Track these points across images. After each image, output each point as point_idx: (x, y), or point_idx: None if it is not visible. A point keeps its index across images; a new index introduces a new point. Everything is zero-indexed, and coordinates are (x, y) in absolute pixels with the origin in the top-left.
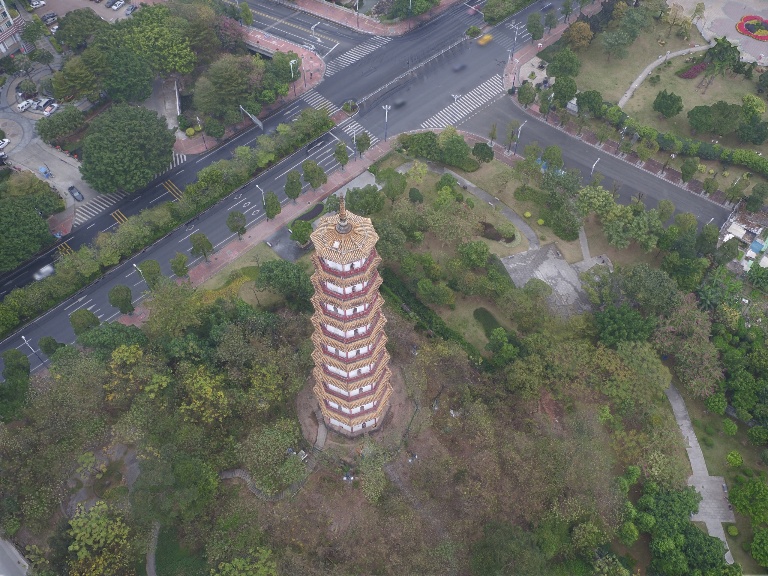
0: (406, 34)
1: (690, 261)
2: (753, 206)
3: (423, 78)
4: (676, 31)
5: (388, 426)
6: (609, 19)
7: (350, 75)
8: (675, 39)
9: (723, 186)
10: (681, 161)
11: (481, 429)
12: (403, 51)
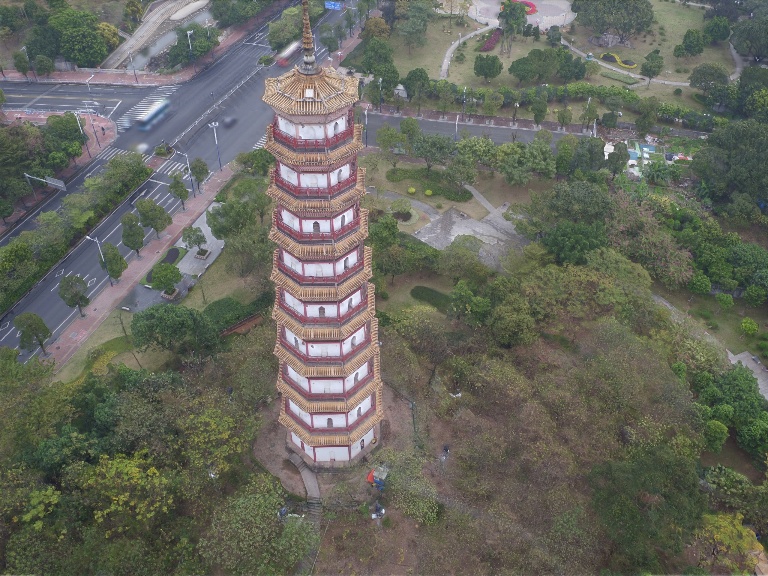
0: (194, 78)
1: (594, 173)
2: (611, 121)
3: (233, 108)
4: (454, 22)
5: (389, 437)
6: (393, 21)
7: (149, 124)
8: (457, 28)
9: (572, 119)
10: (524, 110)
11: (510, 381)
12: (199, 91)
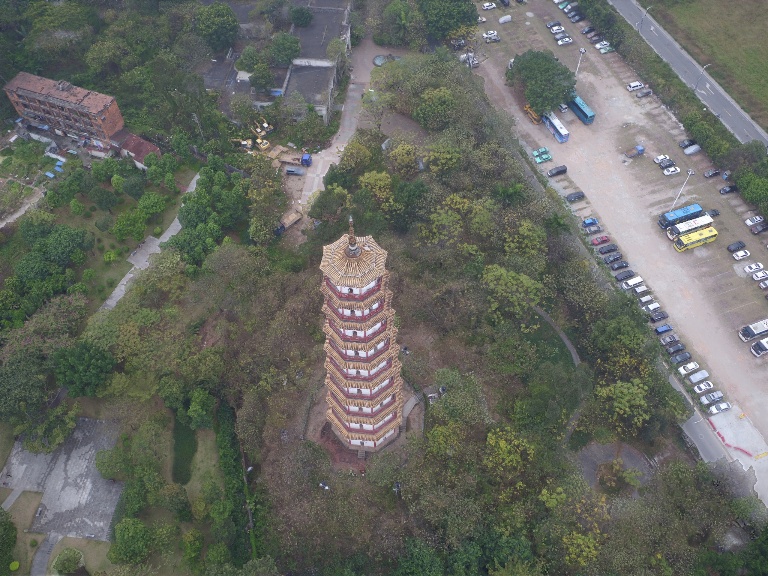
0: None
1: None
2: None
3: None
4: None
5: None
6: None
7: None
8: None
9: None
10: None
11: None
12: None
